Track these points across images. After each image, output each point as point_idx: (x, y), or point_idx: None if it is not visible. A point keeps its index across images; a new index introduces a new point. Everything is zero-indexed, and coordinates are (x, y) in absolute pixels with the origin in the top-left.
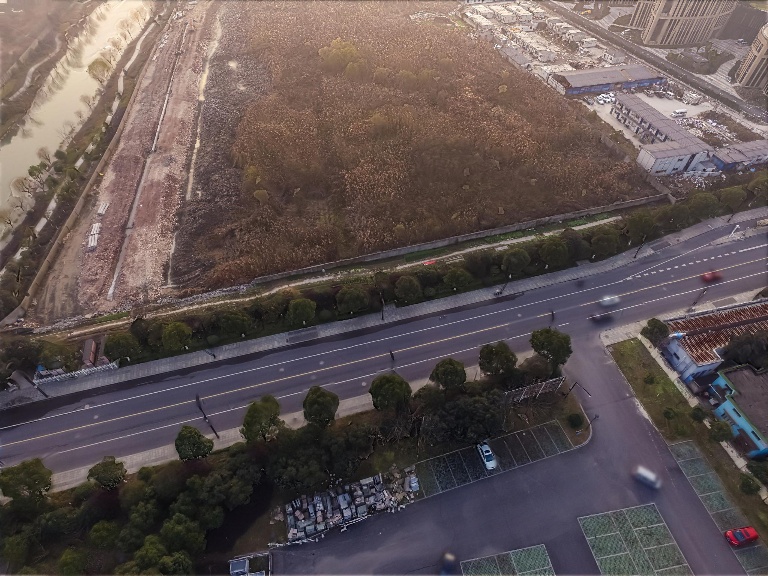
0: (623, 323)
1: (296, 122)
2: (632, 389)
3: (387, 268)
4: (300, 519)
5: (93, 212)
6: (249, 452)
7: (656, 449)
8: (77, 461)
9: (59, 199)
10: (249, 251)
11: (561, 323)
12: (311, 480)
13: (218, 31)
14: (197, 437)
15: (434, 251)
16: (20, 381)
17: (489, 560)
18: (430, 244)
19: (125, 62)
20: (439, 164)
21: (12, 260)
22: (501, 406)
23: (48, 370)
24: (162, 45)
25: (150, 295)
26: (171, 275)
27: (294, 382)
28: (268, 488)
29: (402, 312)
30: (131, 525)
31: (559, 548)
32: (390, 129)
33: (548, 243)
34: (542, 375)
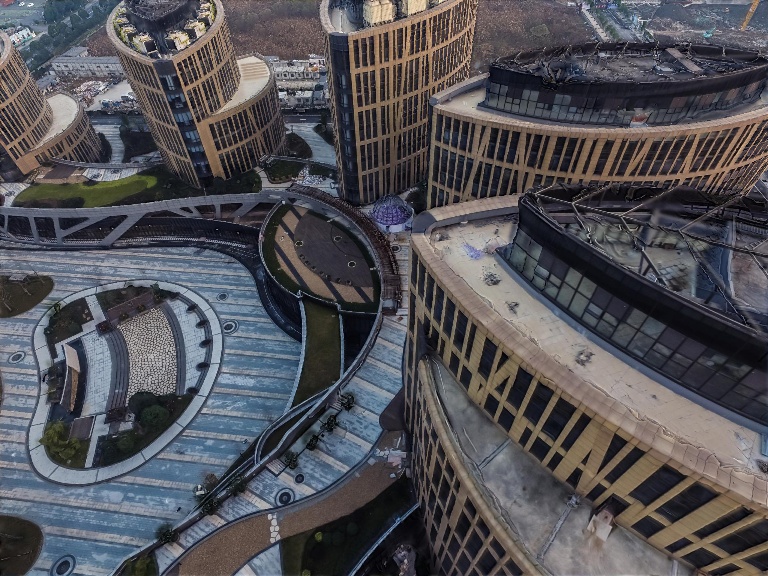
0: None
1: None
2: None
3: None
4: None
5: None
6: None
7: None
8: None
9: None
10: None
11: None
12: None
13: None
14: None
15: None
16: None
17: None
18: None
19: None
20: None
21: None
22: None
23: None
24: None
25: None
26: None
27: (107, 0)
28: None
29: None
30: None
31: None
32: None
33: None
34: None
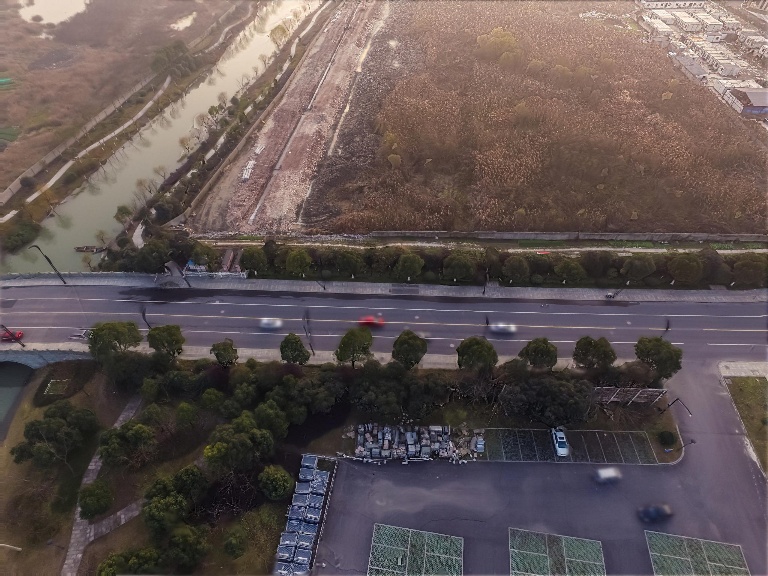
0: (751, 359)
1: (440, 101)
2: (744, 427)
3: (499, 248)
4: (369, 441)
5: (251, 151)
6: (338, 372)
7: (758, 494)
8: (202, 341)
9: (227, 136)
10: (373, 207)
11: (675, 341)
12: (387, 408)
13: (386, 12)
14: (299, 345)
15: (551, 242)
16: (173, 270)
17: (539, 536)
18: (548, 235)
19: (301, 31)
20: (576, 160)
21: (185, 177)
22: (587, 397)
23: (195, 266)
24: (334, 19)
25: (282, 227)
26: (302, 215)
27: (388, 327)
28: (347, 407)
29: (504, 291)
30: (234, 399)
31: (616, 551)
32: (532, 120)
33: (681, 256)
34: (640, 380)
